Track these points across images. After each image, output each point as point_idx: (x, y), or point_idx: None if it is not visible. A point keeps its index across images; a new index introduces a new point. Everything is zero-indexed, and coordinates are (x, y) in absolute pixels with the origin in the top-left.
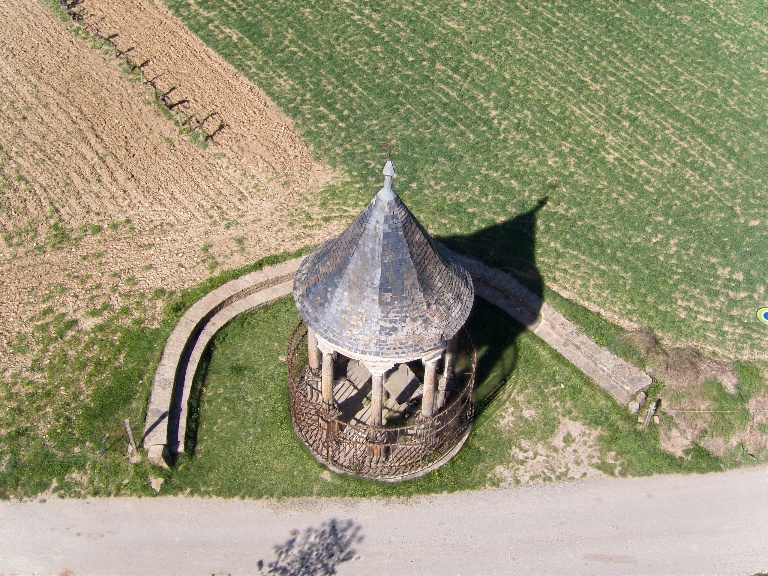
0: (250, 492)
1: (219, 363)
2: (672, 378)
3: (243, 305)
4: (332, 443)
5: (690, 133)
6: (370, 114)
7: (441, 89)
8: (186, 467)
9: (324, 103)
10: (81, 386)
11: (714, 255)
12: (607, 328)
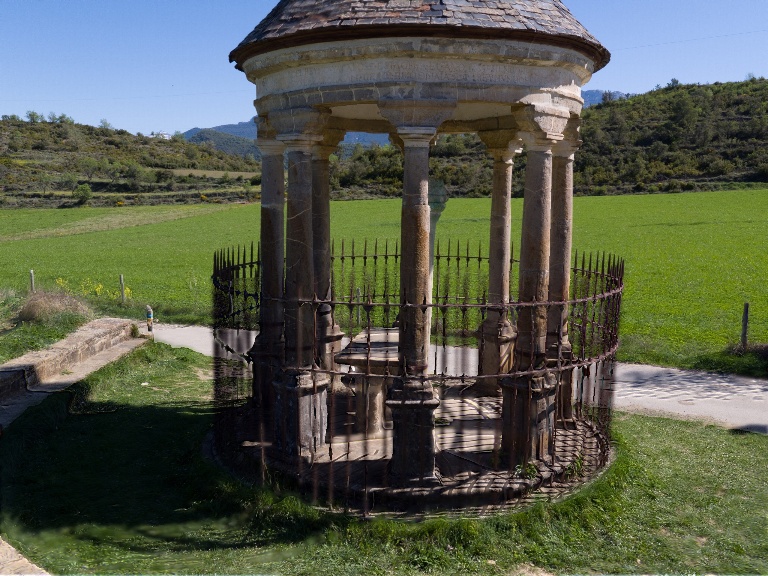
0: (756, 435)
1: None
2: None
3: None
4: None
5: None
6: None
7: None
8: None
9: None
10: None
11: None
12: None
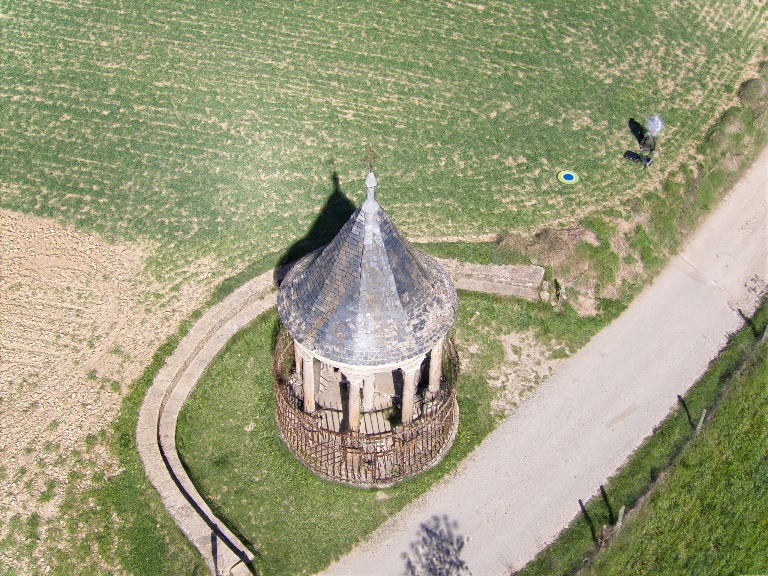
0: (339, 551)
1: (199, 467)
2: (554, 258)
3: (175, 405)
4: (365, 466)
5: (387, 68)
6: (120, 178)
7: (160, 126)
8: (265, 569)
9: (68, 189)
10: (104, 567)
11: (493, 153)
12: (479, 248)
